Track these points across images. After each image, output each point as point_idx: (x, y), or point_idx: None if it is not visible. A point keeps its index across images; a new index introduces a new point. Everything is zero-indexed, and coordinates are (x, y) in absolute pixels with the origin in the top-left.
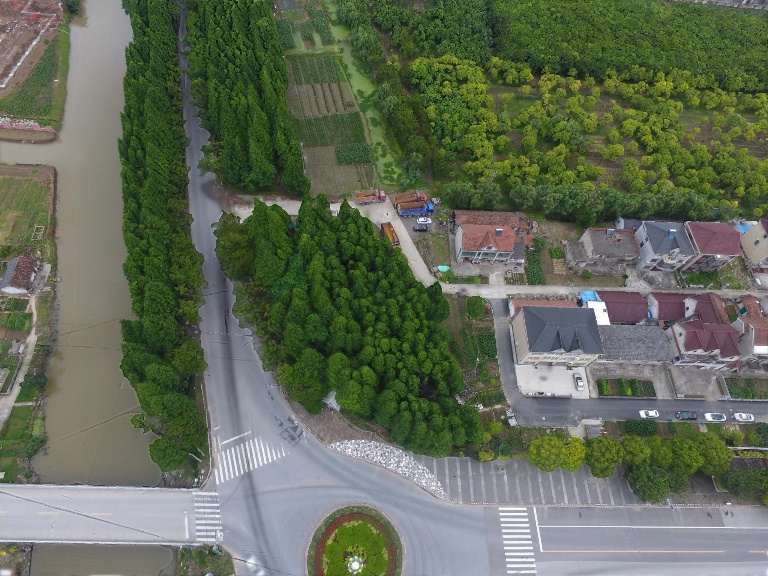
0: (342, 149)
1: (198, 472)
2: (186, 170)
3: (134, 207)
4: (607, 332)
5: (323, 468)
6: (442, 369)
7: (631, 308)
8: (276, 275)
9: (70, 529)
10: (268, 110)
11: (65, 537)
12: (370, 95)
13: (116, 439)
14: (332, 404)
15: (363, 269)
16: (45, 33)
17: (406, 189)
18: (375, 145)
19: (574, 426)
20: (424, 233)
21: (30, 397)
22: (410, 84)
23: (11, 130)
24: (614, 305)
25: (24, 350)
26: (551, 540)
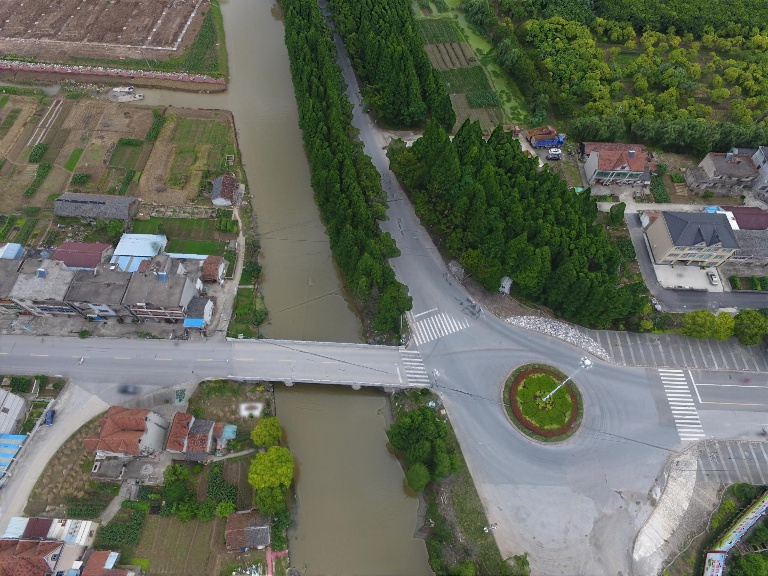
0: (472, 95)
1: (400, 336)
2: (352, 107)
3: (325, 129)
4: (739, 233)
5: (503, 336)
6: (604, 254)
7: (755, 219)
8: (455, 179)
9: (307, 372)
10: (415, 58)
11: (305, 378)
12: (488, 52)
13: (314, 321)
14: (505, 287)
15: (524, 178)
16: (201, 7)
17: (534, 127)
18: (500, 93)
19: (713, 313)
20: (556, 162)
21: (249, 282)
22: (524, 42)
23: (189, 83)
24: (739, 216)
25: (237, 247)
26: (708, 395)
